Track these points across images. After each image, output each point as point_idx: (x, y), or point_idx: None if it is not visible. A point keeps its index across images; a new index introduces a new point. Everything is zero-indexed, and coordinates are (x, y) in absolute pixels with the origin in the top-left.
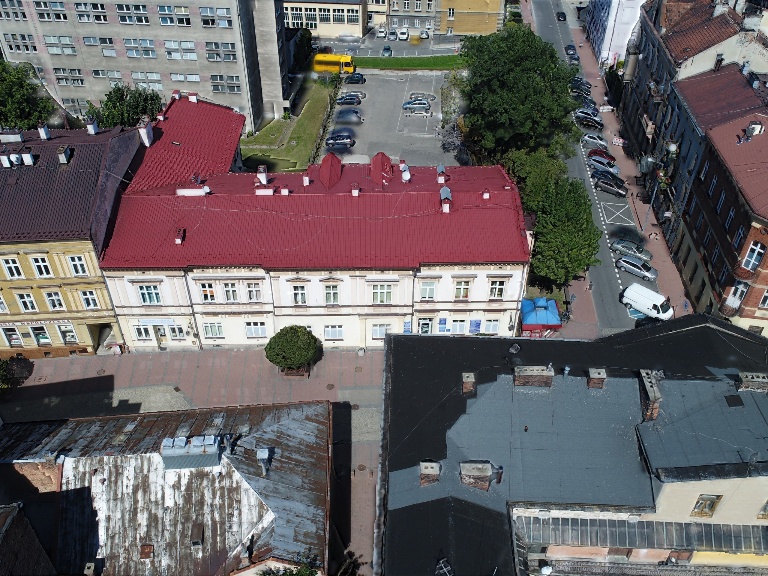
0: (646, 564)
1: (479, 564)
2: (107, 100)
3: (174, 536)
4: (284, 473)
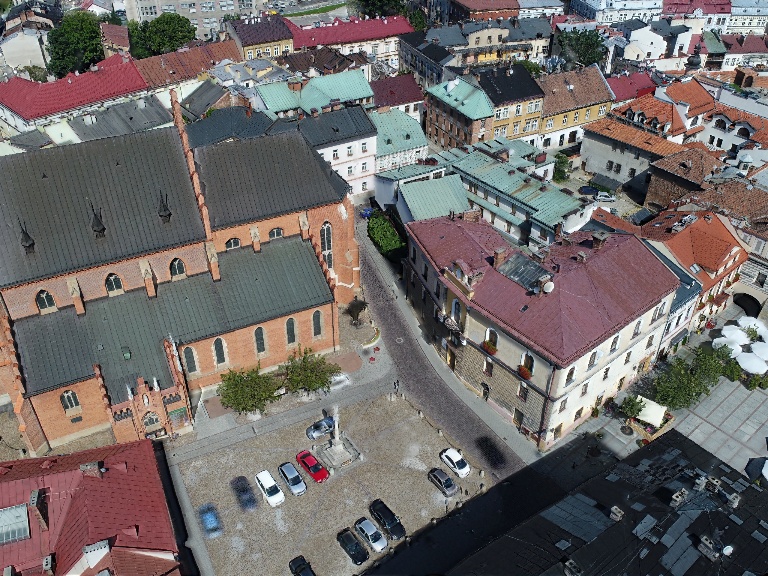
0: None
1: None
2: None
3: (373, 74)
4: None
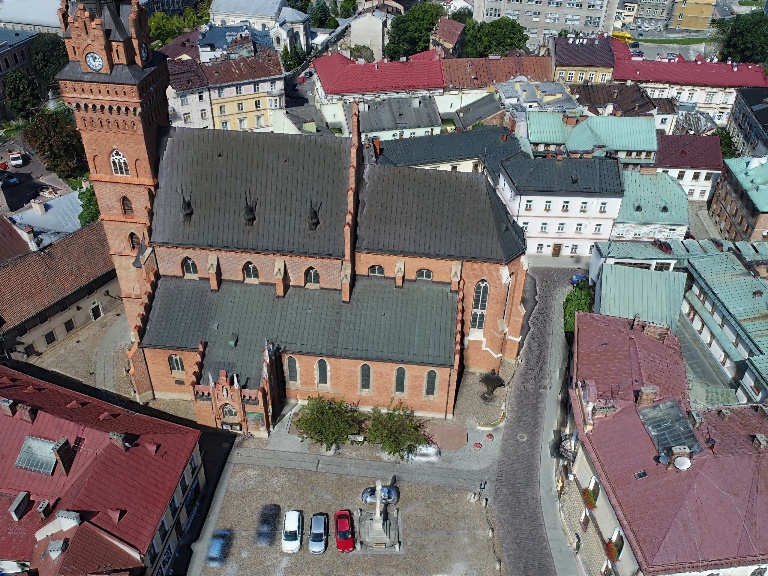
0: None
1: None
2: (559, 35)
3: None
4: None
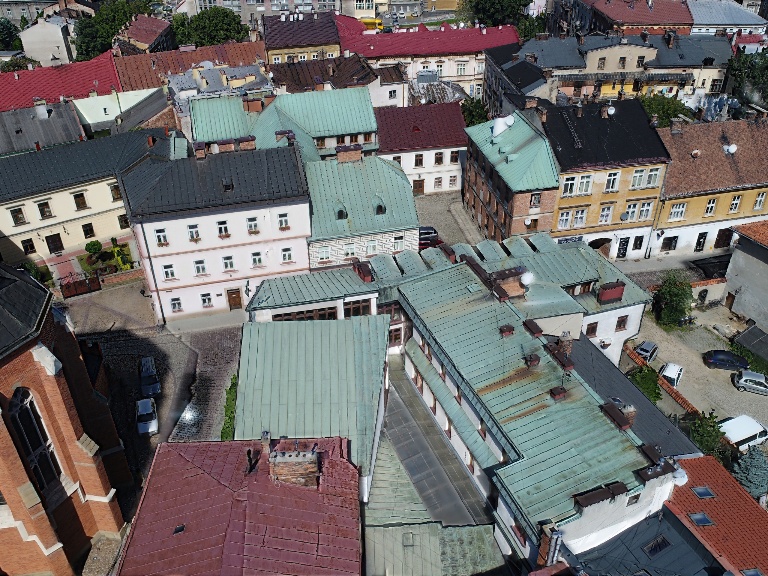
0: None
1: None
2: None
3: None
4: None
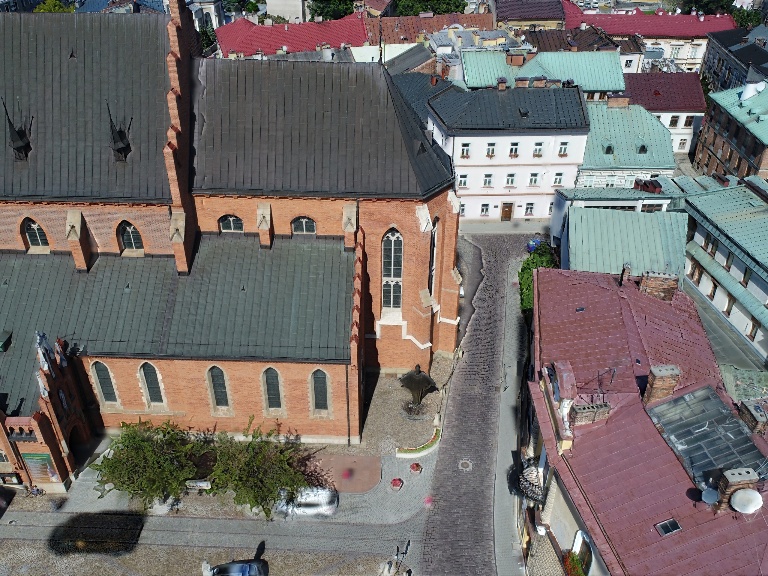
0: None
1: (767, 52)
2: None
3: None
4: None
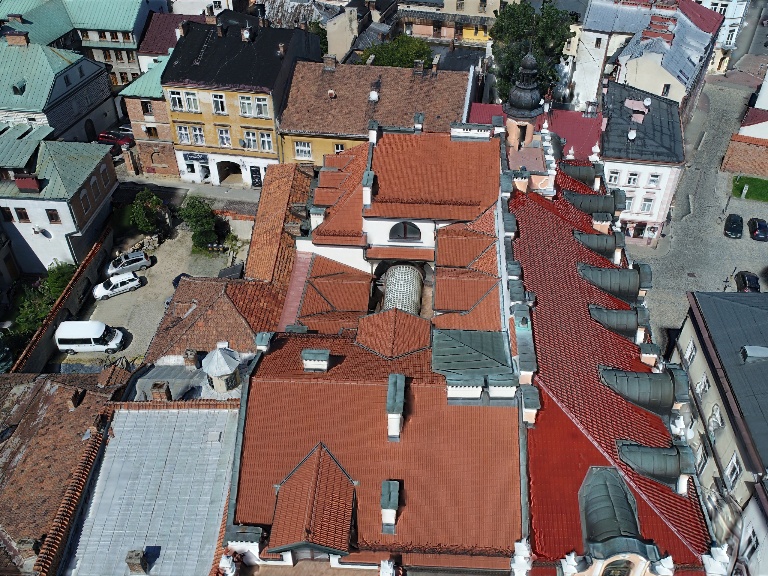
0: (447, 40)
1: None
2: None
3: (289, 20)
4: (331, 14)
